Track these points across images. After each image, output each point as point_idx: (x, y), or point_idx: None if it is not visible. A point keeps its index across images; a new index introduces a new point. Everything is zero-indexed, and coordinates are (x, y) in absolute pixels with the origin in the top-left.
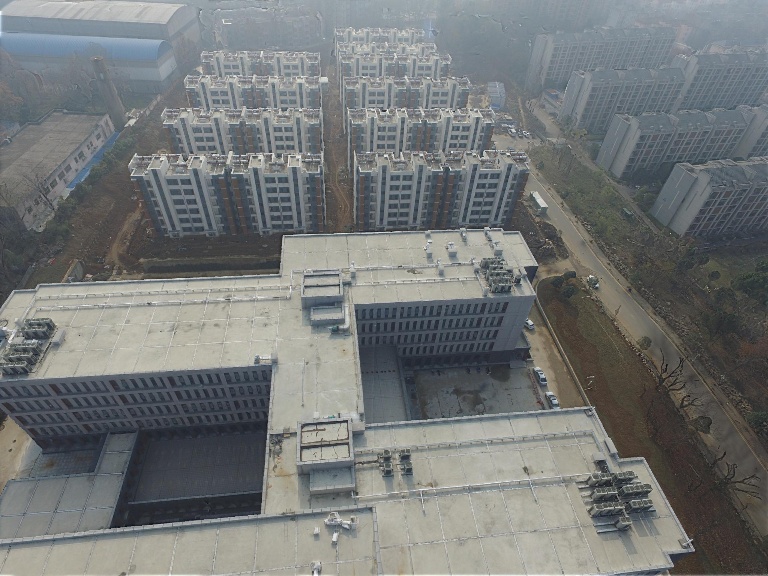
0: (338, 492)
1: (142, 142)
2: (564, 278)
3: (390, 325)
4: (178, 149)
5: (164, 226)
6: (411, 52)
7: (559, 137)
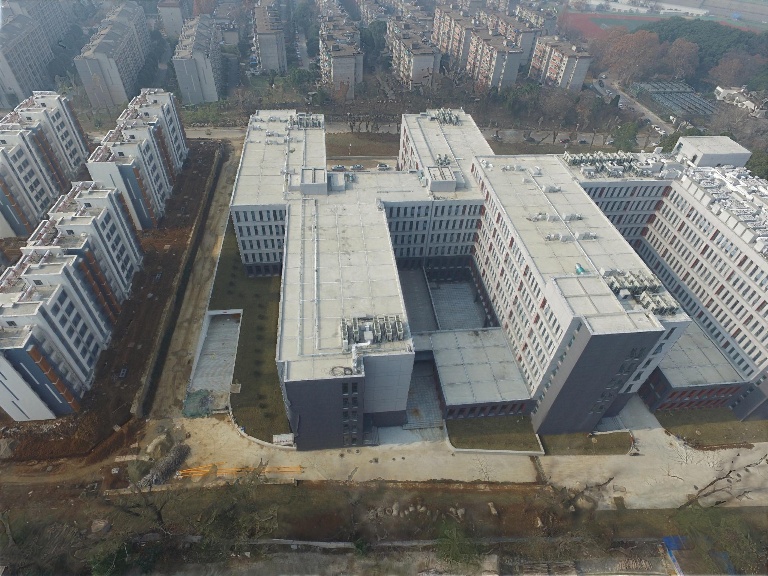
0: None
1: None
2: None
3: None
4: None
5: (74, 386)
6: None
7: None
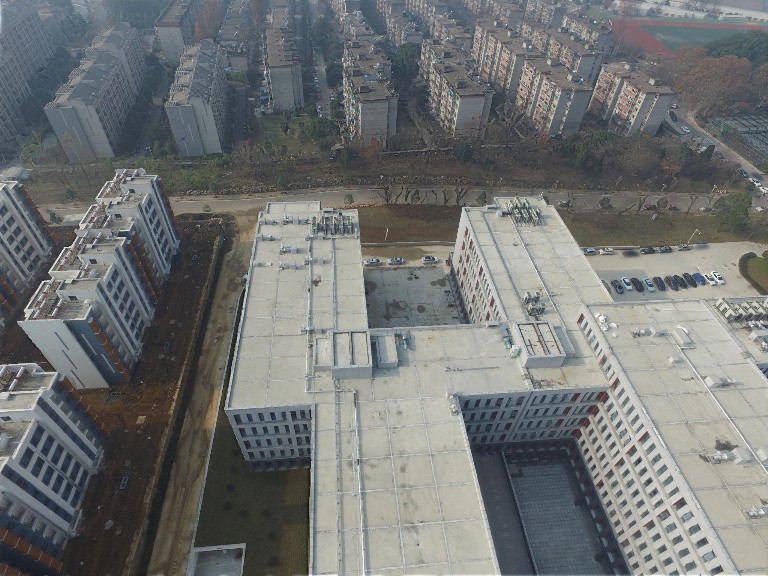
0: None
1: None
2: None
3: None
4: None
5: None
6: None
7: (2, 171)
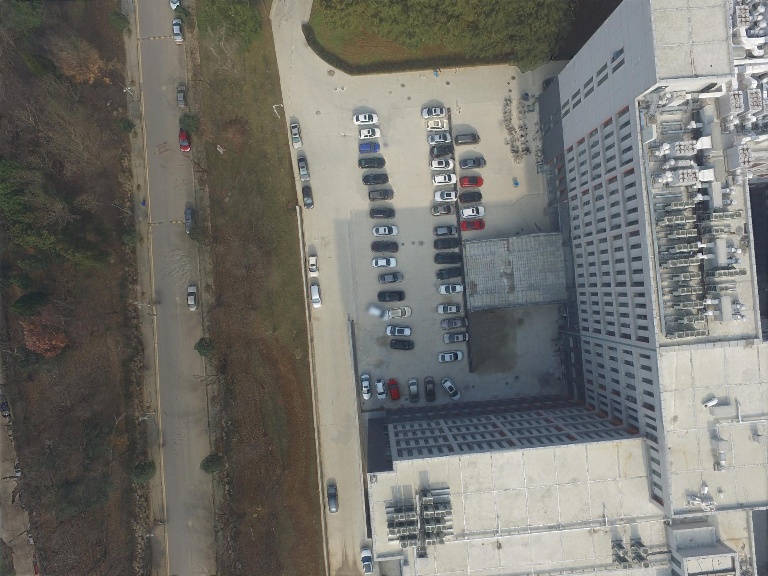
0: (683, 524)
1: None
2: None
3: None
4: None
5: None
6: None
7: None
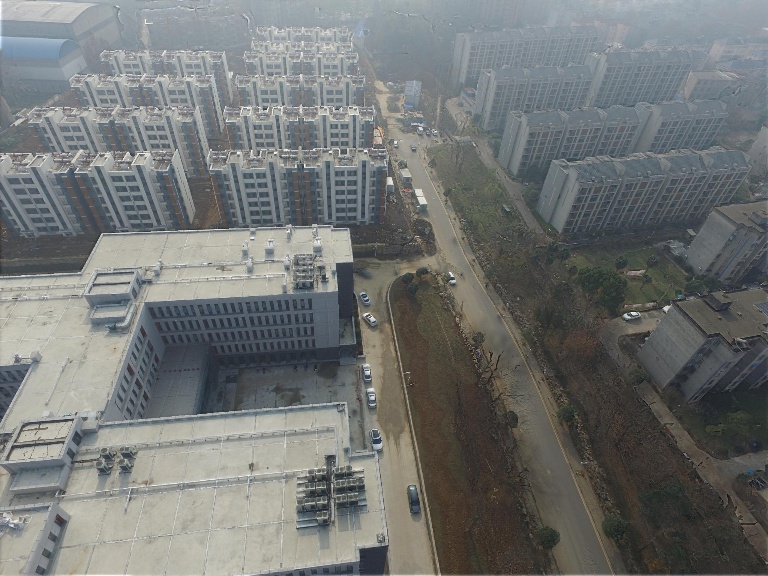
0: (45, 491)
1: (27, 142)
2: (416, 275)
3: (195, 323)
4: (49, 148)
5: (17, 226)
6: (326, 51)
7: None
